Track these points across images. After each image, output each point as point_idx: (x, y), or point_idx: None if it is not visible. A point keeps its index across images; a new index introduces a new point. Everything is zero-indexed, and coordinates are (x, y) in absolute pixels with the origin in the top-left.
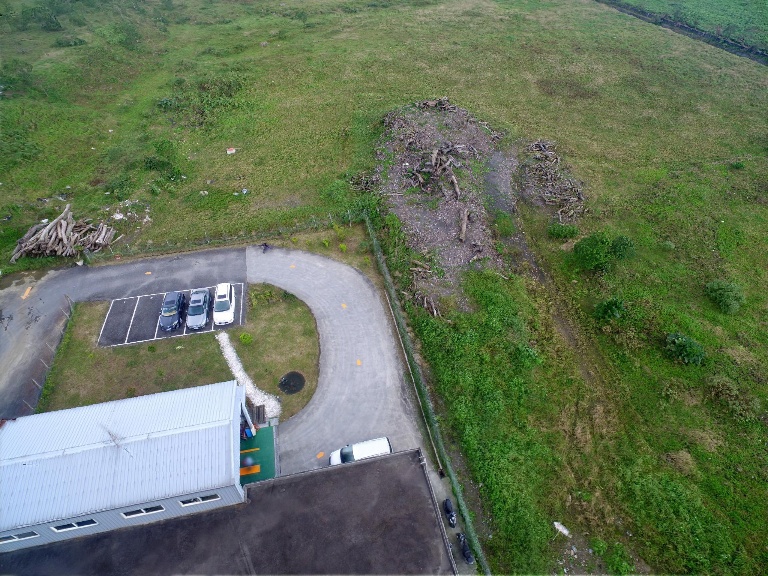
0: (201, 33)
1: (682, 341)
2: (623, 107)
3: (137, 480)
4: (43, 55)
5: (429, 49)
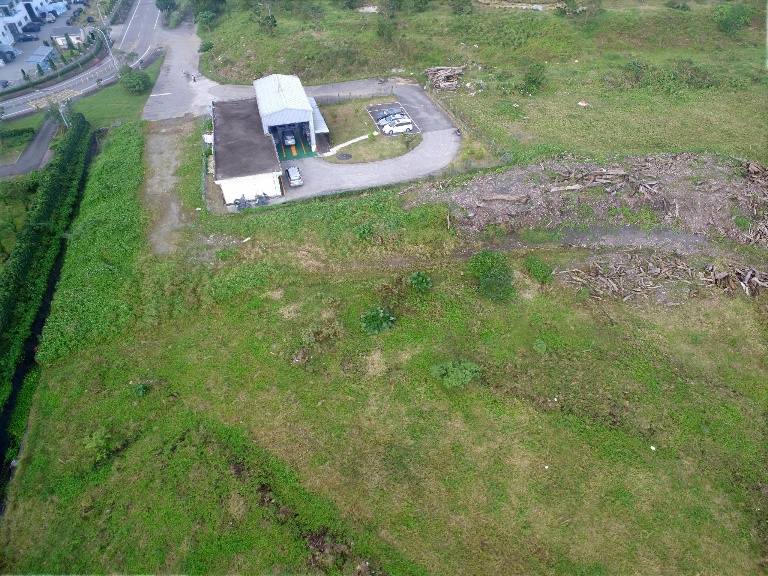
0: None
1: (380, 312)
2: None
3: None
4: (643, 6)
5: None
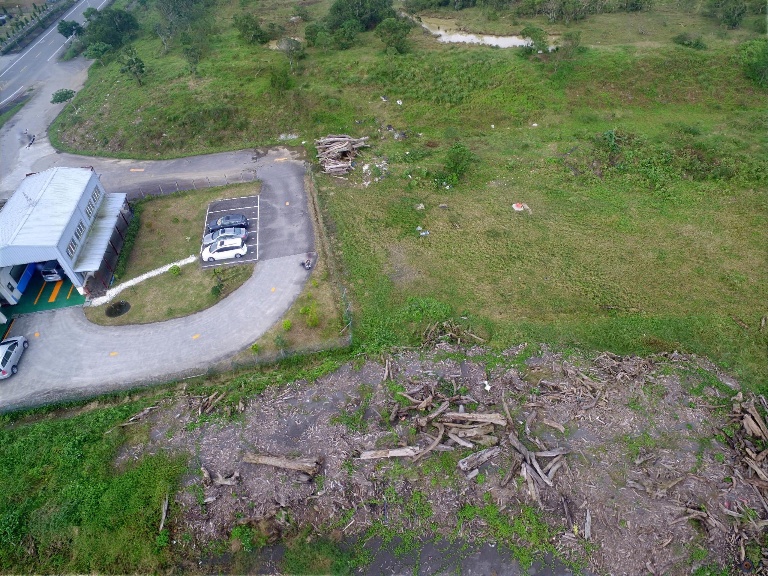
0: None
1: None
2: None
3: (4, 219)
4: (642, 41)
5: None
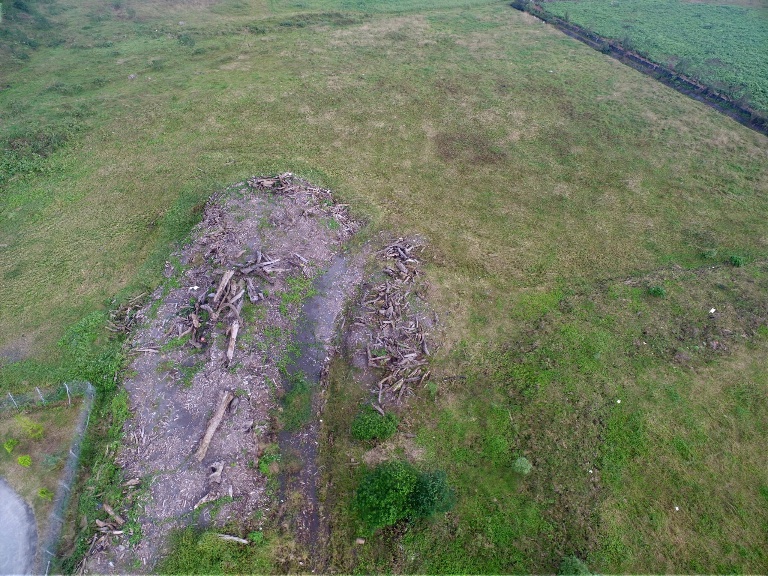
0: (68, 60)
1: None
2: (532, 178)
3: None
4: None
5: (325, 86)
